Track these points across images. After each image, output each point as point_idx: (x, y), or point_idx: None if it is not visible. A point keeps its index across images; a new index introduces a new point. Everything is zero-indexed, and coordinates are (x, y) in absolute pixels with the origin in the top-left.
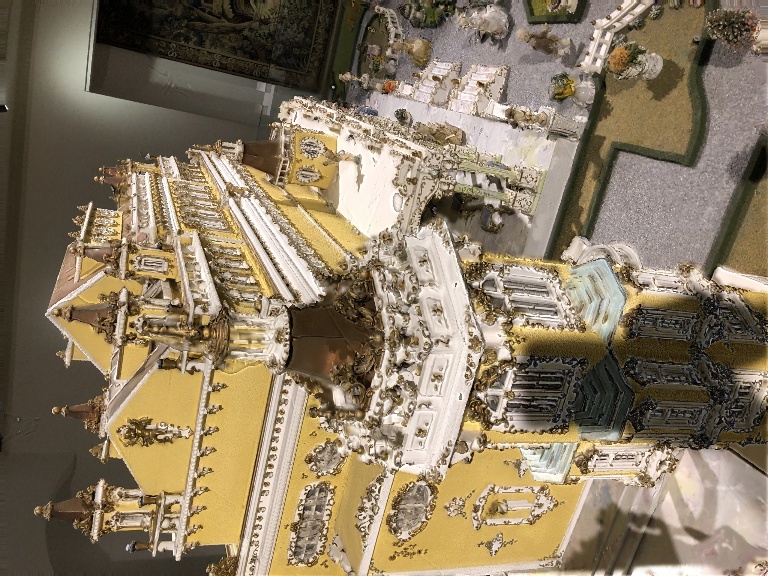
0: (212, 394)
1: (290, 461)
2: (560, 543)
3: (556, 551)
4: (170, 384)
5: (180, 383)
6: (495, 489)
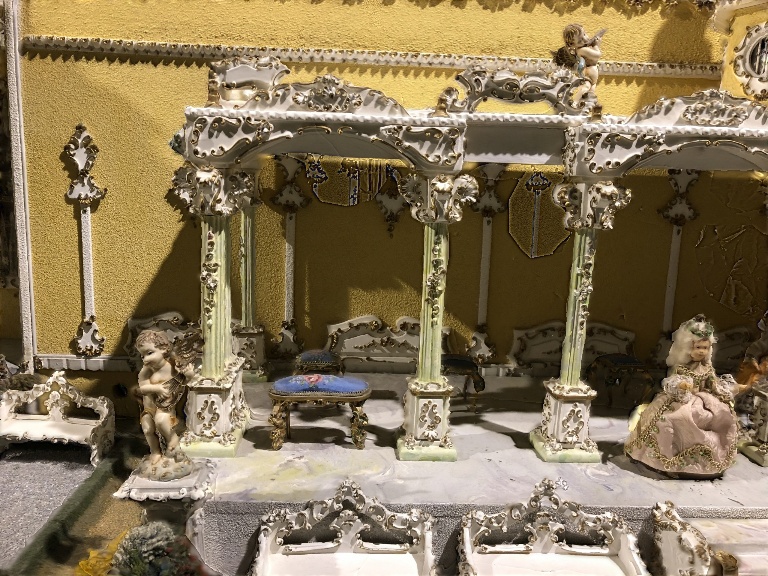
0: None
1: None
2: None
3: None
4: None
5: None
6: None
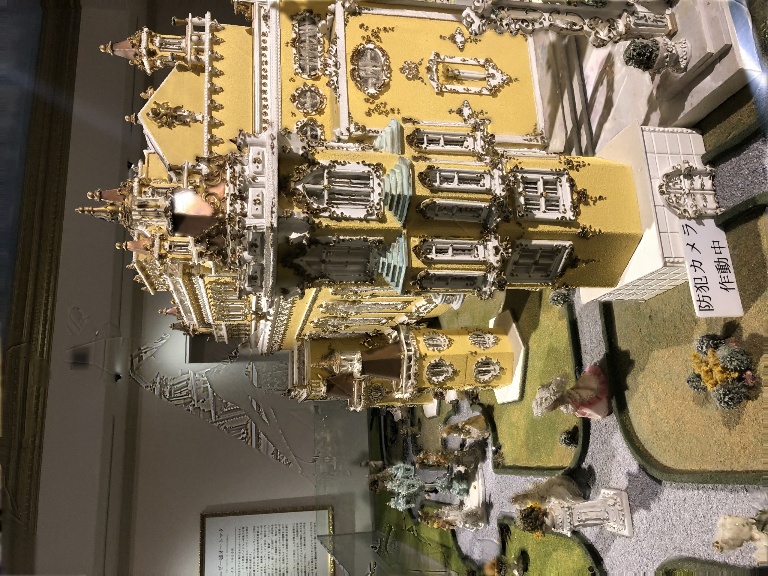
0: (214, 80)
1: (277, 98)
2: (537, 123)
3: (536, 130)
4: (183, 83)
5: (191, 83)
6: (441, 57)
